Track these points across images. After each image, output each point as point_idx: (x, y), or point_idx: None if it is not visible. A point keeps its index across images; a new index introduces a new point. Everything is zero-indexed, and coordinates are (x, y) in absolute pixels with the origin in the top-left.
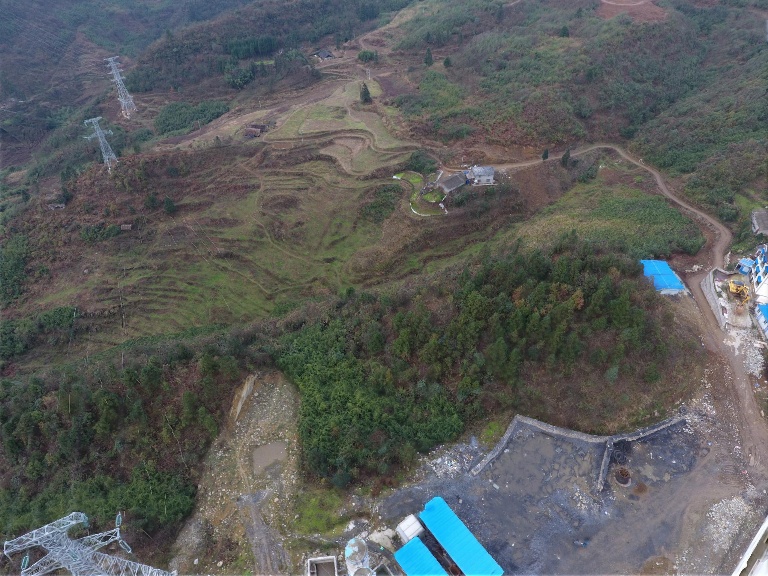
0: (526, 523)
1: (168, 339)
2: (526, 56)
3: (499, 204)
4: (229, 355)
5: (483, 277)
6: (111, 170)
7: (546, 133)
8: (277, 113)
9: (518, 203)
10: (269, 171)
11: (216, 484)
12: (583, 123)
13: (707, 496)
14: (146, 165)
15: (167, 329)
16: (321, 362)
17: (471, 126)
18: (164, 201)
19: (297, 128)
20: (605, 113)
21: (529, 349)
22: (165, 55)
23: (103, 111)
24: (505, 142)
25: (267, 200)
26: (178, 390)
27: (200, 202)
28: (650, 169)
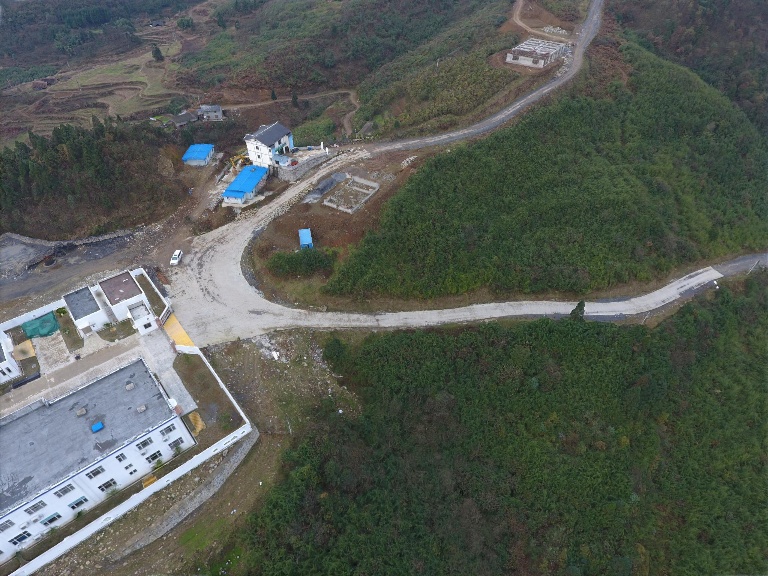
0: None
1: None
2: (296, 17)
3: (226, 137)
4: None
5: None
6: None
7: (280, 78)
8: (79, 71)
9: None
10: (44, 116)
11: None
12: (326, 72)
13: (97, 269)
14: None
15: None
16: None
17: (224, 75)
18: None
19: (83, 81)
20: (346, 63)
21: None
22: (0, 25)
23: None
24: (242, 86)
25: None
26: None
27: None
28: None
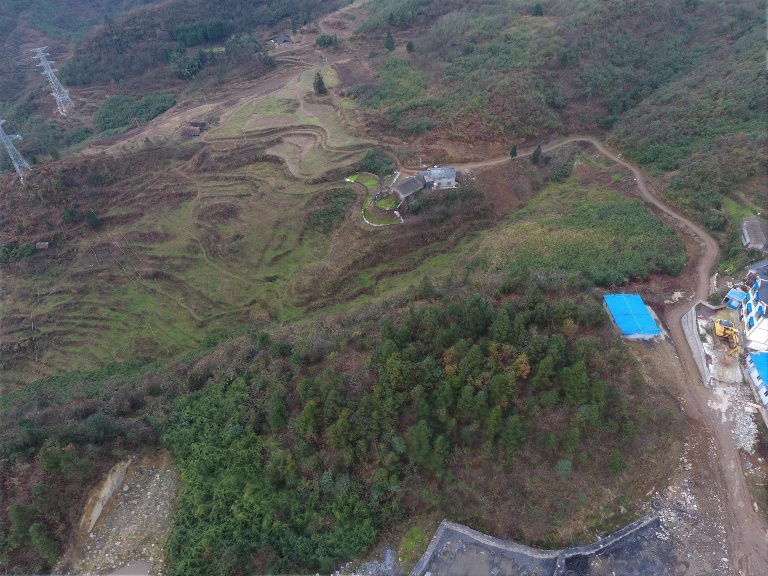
0: None
1: (80, 380)
2: (495, 38)
3: (462, 209)
4: (93, 438)
5: (409, 332)
6: (23, 180)
7: (515, 127)
8: (223, 107)
9: (483, 208)
10: (207, 176)
11: None
12: (557, 114)
13: None
14: (64, 173)
15: (84, 365)
16: (213, 439)
17: (432, 120)
18: (85, 214)
19: (241, 125)
20: (581, 102)
21: (462, 430)
22: (104, 43)
23: (38, 107)
24: (469, 138)
25: (203, 210)
26: (15, 494)
27: (128, 214)
28: (630, 166)
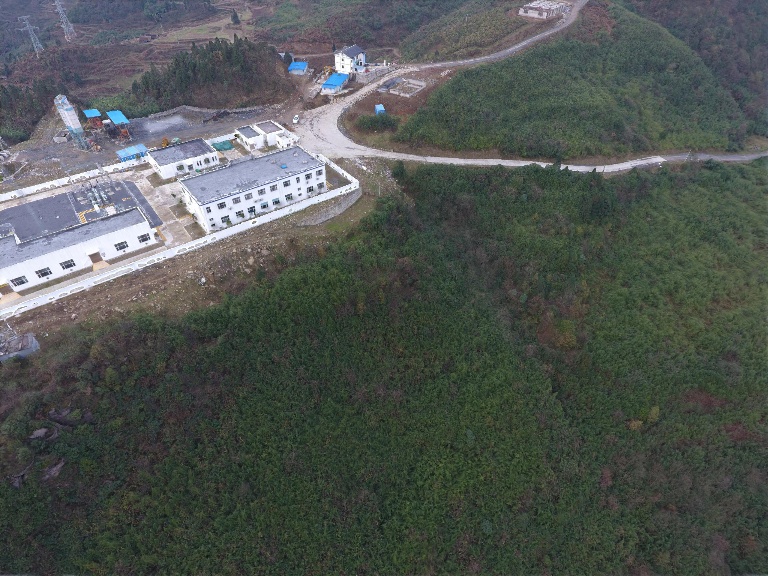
0: (161, 128)
1: None
2: None
3: None
4: None
5: None
6: (39, 55)
7: (339, 35)
8: (172, 31)
9: None
10: None
11: (38, 128)
12: (374, 32)
13: None
14: (63, 52)
15: None
16: None
17: None
18: (74, 75)
19: (179, 37)
20: (391, 26)
21: None
22: None
23: None
24: (309, 40)
25: None
26: None
27: (100, 79)
28: None
